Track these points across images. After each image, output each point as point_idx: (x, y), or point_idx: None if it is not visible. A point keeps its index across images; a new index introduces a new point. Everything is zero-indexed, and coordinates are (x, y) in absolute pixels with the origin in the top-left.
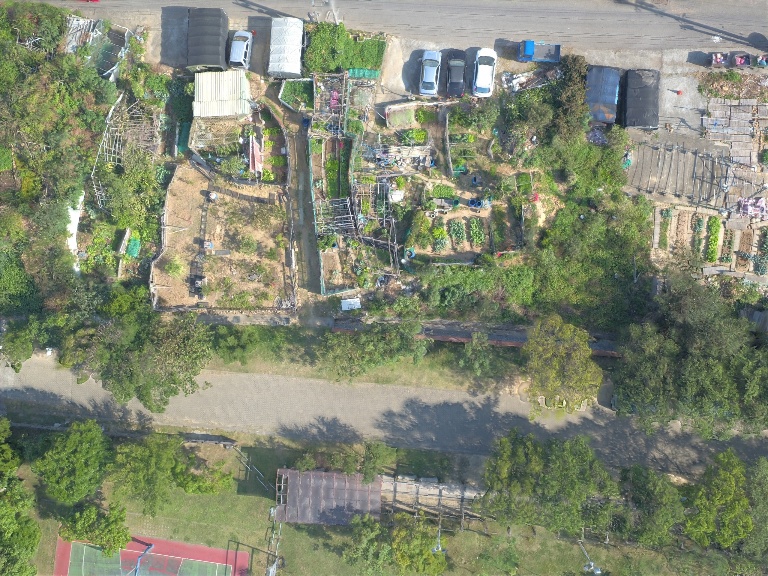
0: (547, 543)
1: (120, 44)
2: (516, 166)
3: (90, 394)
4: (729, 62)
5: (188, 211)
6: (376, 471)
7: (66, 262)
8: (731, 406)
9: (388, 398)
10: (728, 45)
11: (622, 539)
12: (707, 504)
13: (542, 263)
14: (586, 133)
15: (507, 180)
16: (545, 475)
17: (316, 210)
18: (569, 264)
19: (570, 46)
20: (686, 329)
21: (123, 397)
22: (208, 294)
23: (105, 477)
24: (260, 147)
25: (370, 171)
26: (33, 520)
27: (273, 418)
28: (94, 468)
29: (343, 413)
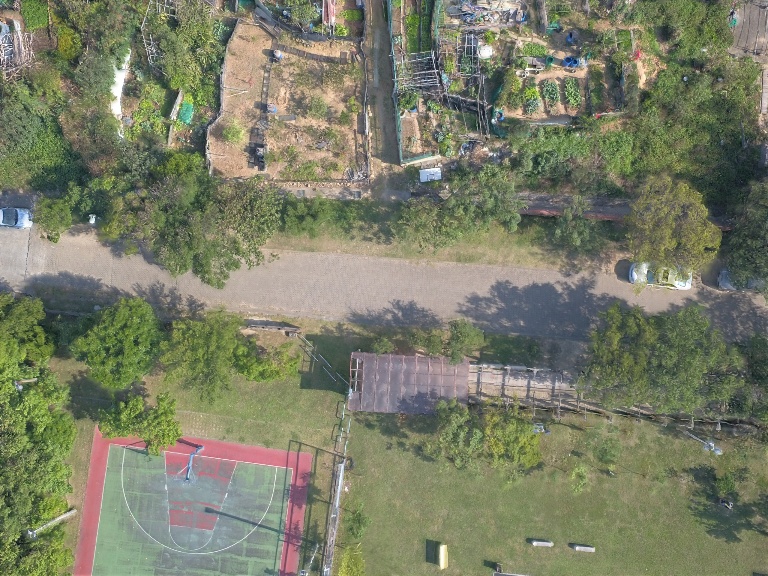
0: (646, 437)
1: None
2: (614, 22)
3: (133, 277)
4: None
5: (248, 72)
6: (463, 353)
7: (110, 124)
8: None
9: (471, 279)
10: None
11: (729, 432)
12: None
13: (642, 129)
14: None
15: (609, 32)
16: (661, 346)
17: (397, 65)
18: (672, 129)
19: None
20: None
21: (178, 269)
22: (269, 165)
23: (154, 362)
24: None
25: (453, 28)
26: (68, 414)
27: (342, 302)
28: (145, 346)
29: (421, 295)
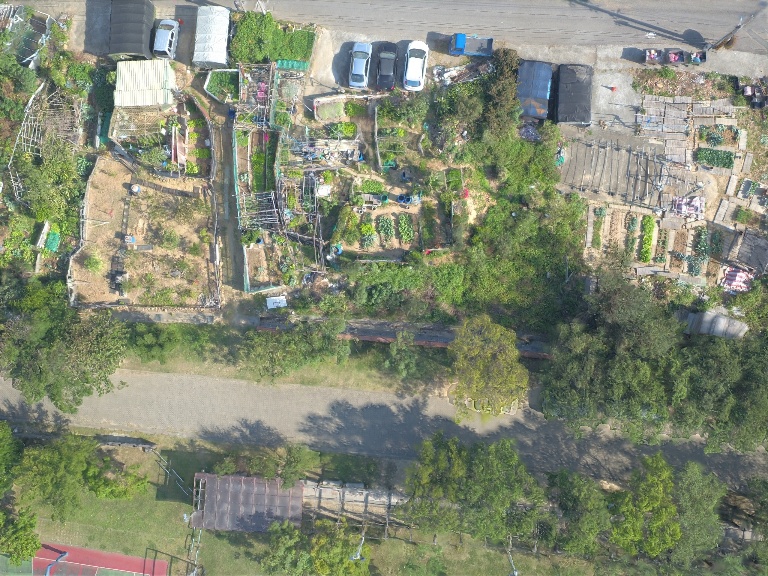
0: (476, 552)
1: (43, 31)
2: (447, 161)
3: (4, 394)
4: (664, 59)
5: (110, 204)
6: (297, 476)
7: None
8: (659, 409)
9: (314, 400)
10: (663, 42)
11: (553, 548)
12: (633, 511)
13: None
14: (518, 129)
15: (435, 175)
16: (468, 480)
17: (239, 204)
18: (500, 263)
19: (503, 40)
20: (616, 330)
21: (33, 396)
22: (129, 290)
23: None
24: (184, 139)
25: (297, 165)
26: None
27: (194, 420)
28: None
29: (267, 415)
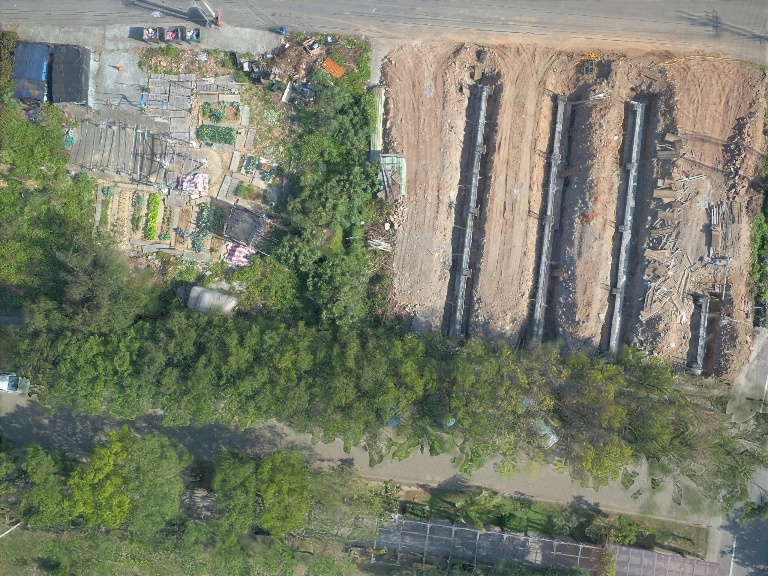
0: None
1: None
2: None
3: None
4: None
5: None
6: None
7: None
8: (106, 383)
9: None
10: (168, 20)
11: None
12: (80, 484)
13: None
14: (26, 111)
15: None
16: None
17: None
18: (8, 244)
19: (16, 23)
20: None
21: None
22: None
23: None
24: None
25: None
26: None
27: None
28: None
29: None
